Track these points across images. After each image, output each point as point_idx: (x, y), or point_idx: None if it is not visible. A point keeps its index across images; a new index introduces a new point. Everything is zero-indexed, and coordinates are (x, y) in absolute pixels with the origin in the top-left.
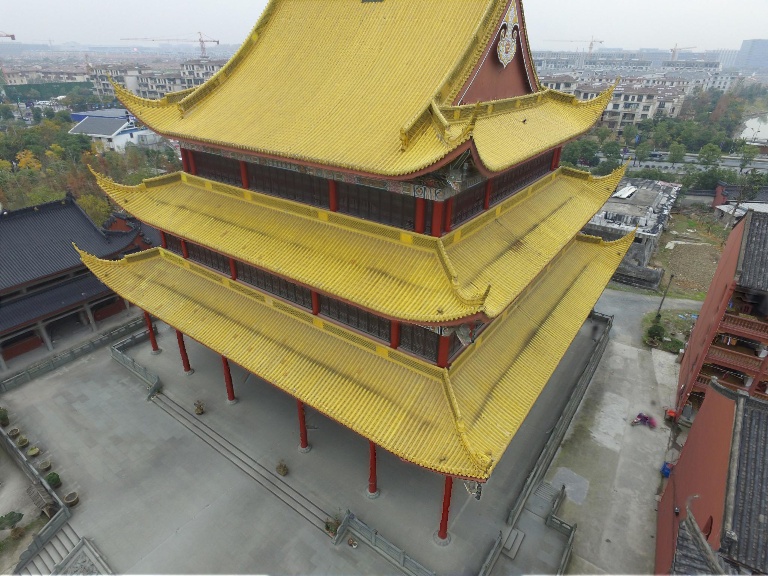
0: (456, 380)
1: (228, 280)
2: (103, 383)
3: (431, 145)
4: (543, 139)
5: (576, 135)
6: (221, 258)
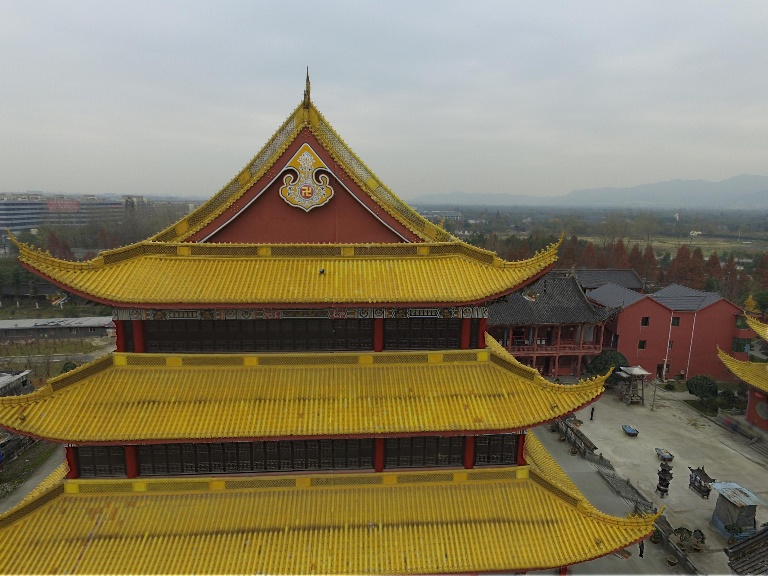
0: None
1: None
2: None
3: None
4: None
5: None
6: None
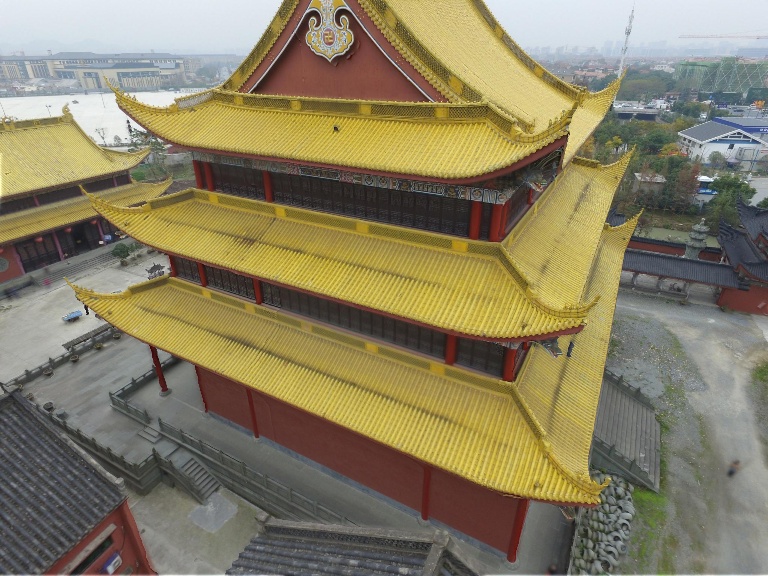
0: (174, 292)
1: None
2: None
3: None
4: (306, 150)
5: (394, 171)
6: None
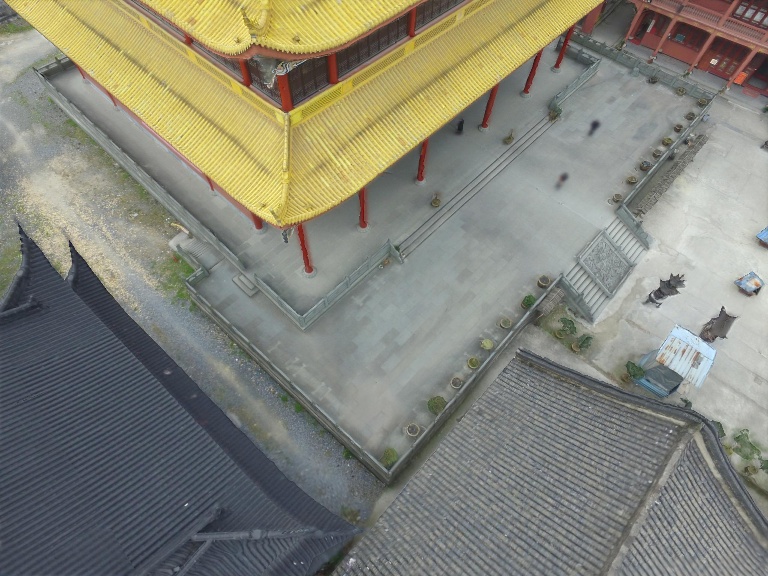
0: None
1: (414, 40)
2: (361, 324)
3: None
4: None
5: None
6: (395, 22)
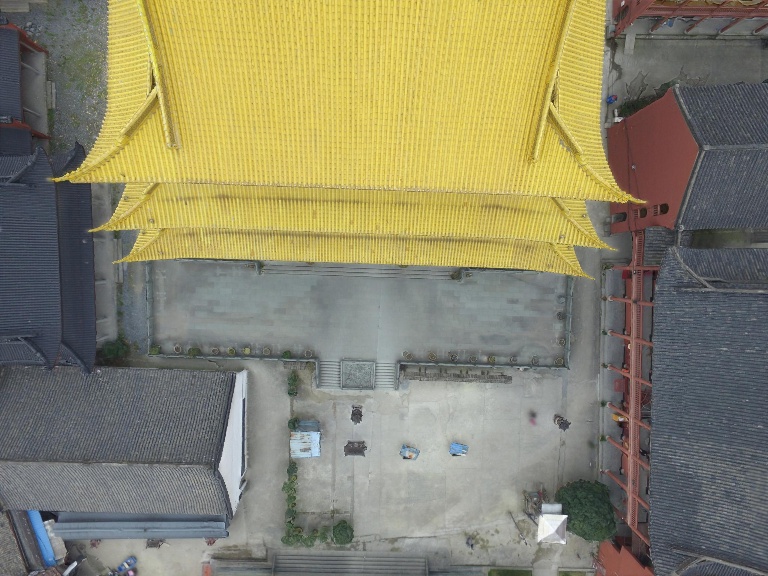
0: None
1: None
2: (208, 284)
3: (558, 156)
4: None
5: None
6: None
